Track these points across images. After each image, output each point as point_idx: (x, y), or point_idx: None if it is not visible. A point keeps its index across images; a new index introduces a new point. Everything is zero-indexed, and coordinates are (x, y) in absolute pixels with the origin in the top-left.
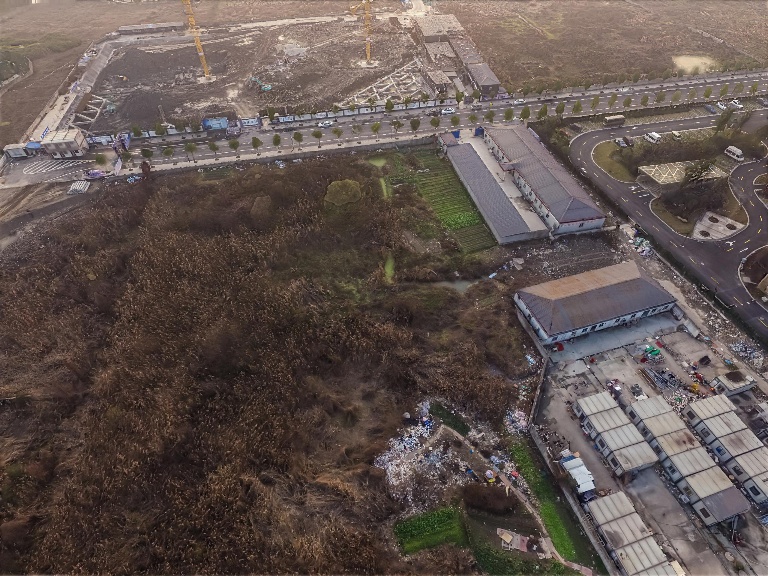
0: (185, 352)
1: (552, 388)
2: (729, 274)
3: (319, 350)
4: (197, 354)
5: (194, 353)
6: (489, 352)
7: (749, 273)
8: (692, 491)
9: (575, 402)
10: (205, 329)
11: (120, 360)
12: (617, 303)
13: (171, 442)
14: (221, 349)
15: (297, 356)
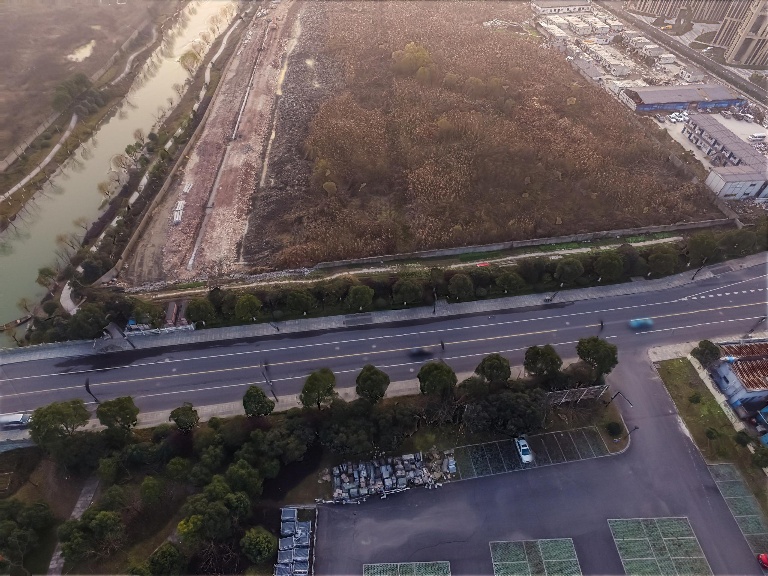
0: (414, 4)
1: (540, 19)
2: (618, 6)
3: (460, 6)
4: (418, 6)
5: (417, 5)
6: (519, 13)
7: (626, 5)
8: (576, 27)
9: (546, 17)
10: (419, 1)
11: (394, 3)
12: (568, 3)
13: (416, 15)
14: (427, 3)
15: (452, 7)
